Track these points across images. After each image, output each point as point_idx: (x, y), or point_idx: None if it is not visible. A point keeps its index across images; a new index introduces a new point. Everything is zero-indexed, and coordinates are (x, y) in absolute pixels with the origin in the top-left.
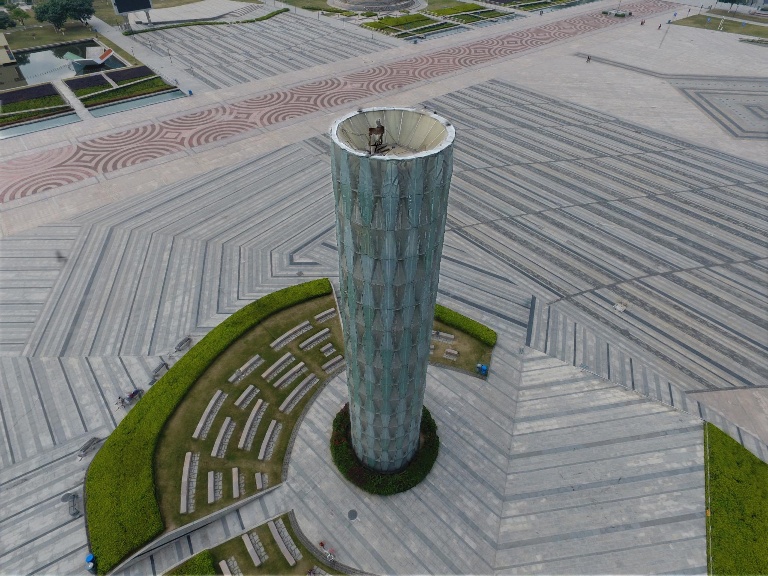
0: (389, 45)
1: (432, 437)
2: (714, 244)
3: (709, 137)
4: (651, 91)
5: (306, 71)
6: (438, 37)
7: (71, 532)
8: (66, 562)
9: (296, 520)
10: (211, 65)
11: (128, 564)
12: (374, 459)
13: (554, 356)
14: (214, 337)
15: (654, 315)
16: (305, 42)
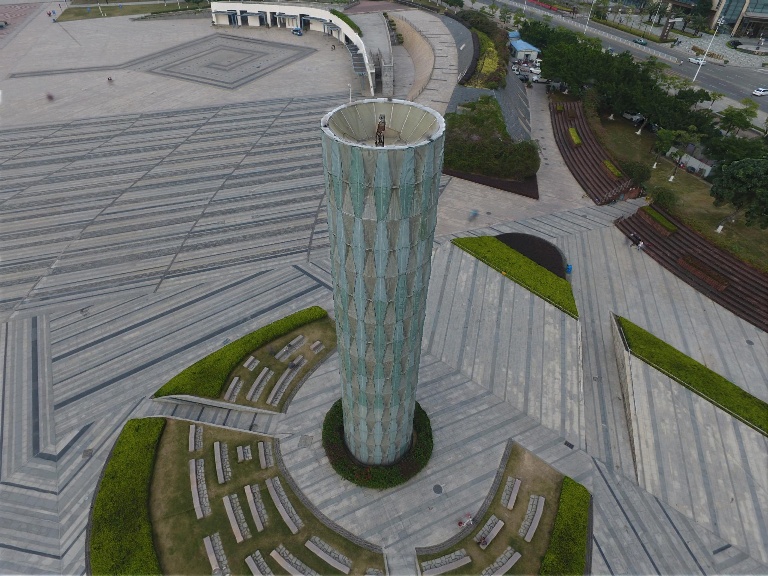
0: None
1: None
2: (318, 159)
3: (218, 97)
4: (131, 82)
5: None
6: None
7: None
8: None
9: (427, 547)
10: None
11: None
12: (405, 443)
13: None
14: None
15: None
16: None
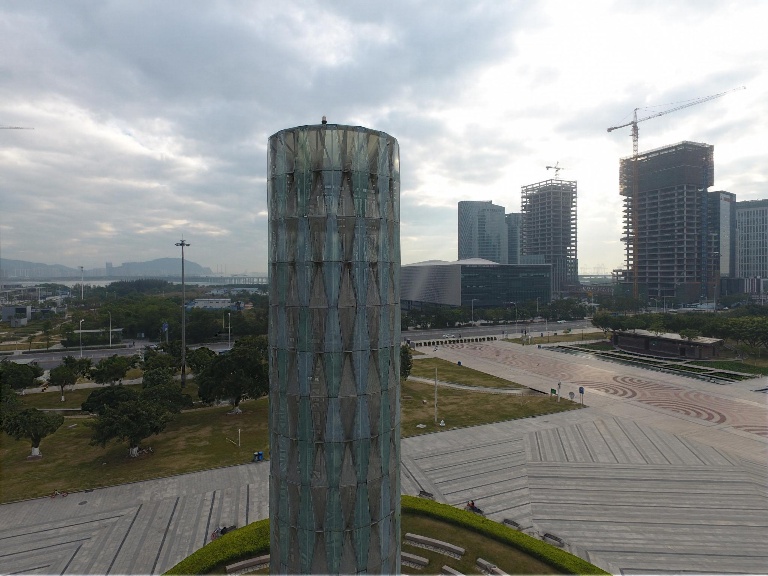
0: None
1: None
2: None
3: None
4: None
5: None
6: None
7: None
8: None
9: None
10: None
11: None
12: None
13: None
14: None
15: None
16: None
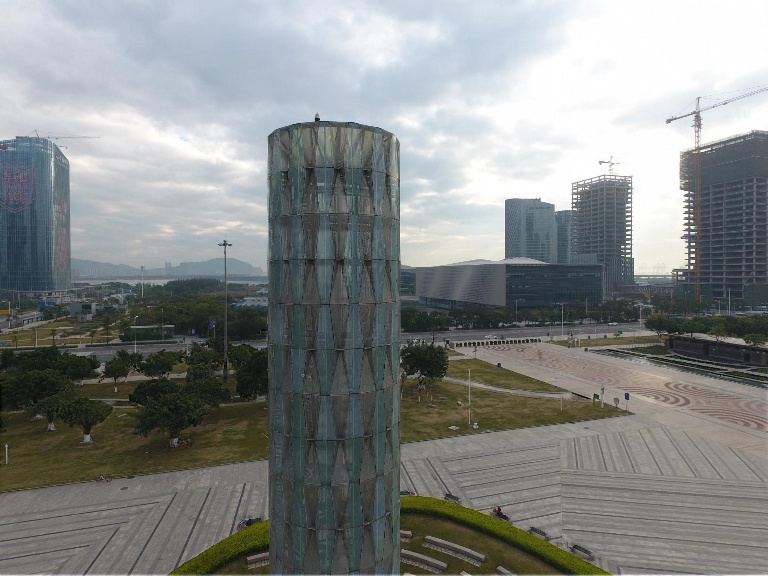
0: None
1: None
2: None
3: None
4: None
5: None
6: None
7: None
8: None
9: None
10: None
11: None
12: None
13: None
14: (583, 564)
15: None
16: None
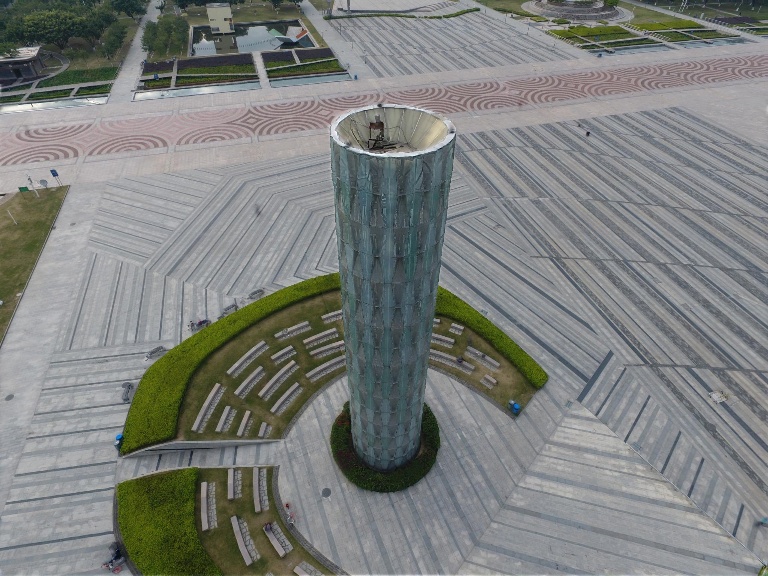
0: (568, 55)
1: (429, 453)
2: None
3: None
4: None
5: (470, 71)
6: (630, 53)
7: (118, 412)
8: (105, 433)
9: (278, 476)
10: (384, 55)
11: (142, 453)
12: (362, 450)
13: (605, 422)
14: (280, 295)
15: (762, 420)
16: (482, 43)
